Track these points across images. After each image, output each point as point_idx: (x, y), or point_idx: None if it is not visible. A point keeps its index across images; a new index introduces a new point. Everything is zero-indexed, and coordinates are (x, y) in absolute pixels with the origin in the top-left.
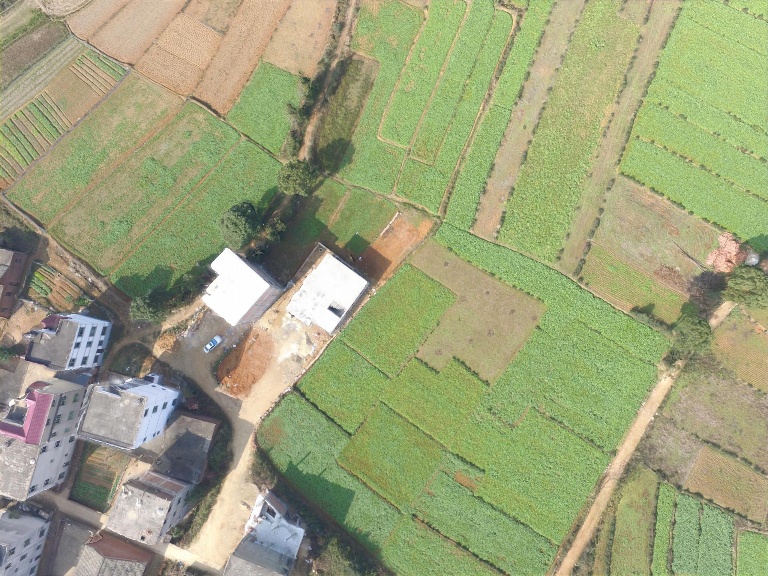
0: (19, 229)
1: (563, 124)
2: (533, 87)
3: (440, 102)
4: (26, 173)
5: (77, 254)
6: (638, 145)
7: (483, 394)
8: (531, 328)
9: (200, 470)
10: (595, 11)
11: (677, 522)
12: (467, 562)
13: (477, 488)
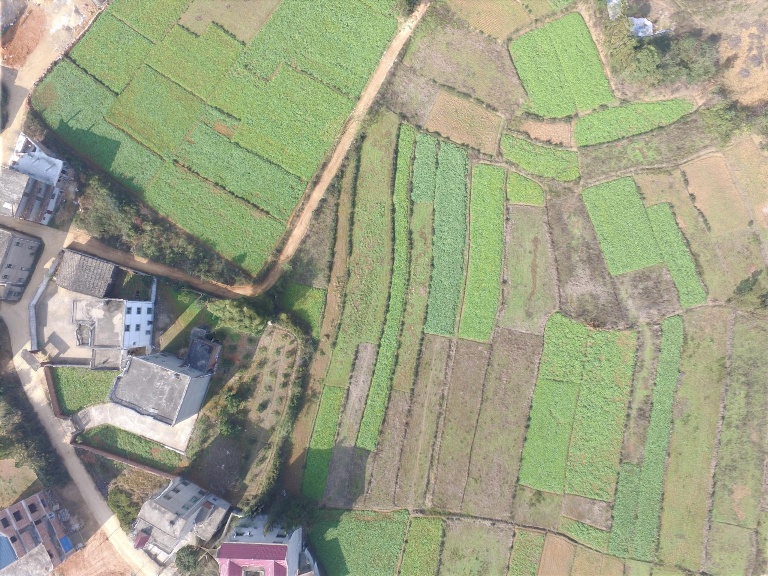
0: None
1: None
2: None
3: None
4: None
5: None
6: None
7: (239, 53)
8: None
9: None
10: None
11: (416, 158)
12: (224, 199)
13: (234, 135)
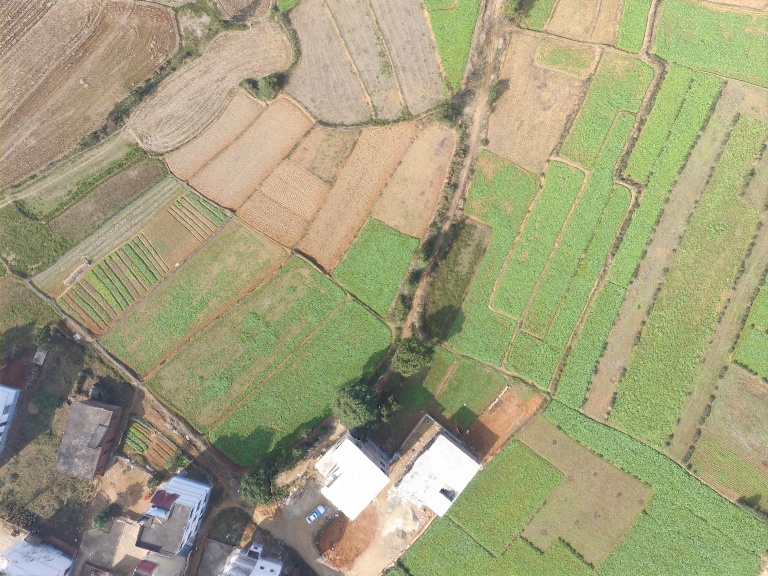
0: (113, 379)
1: (678, 307)
2: (649, 266)
3: (554, 275)
4: (121, 320)
5: (174, 410)
6: (753, 334)
7: None
8: (637, 512)
9: None
10: (716, 193)
11: None
12: None
13: None
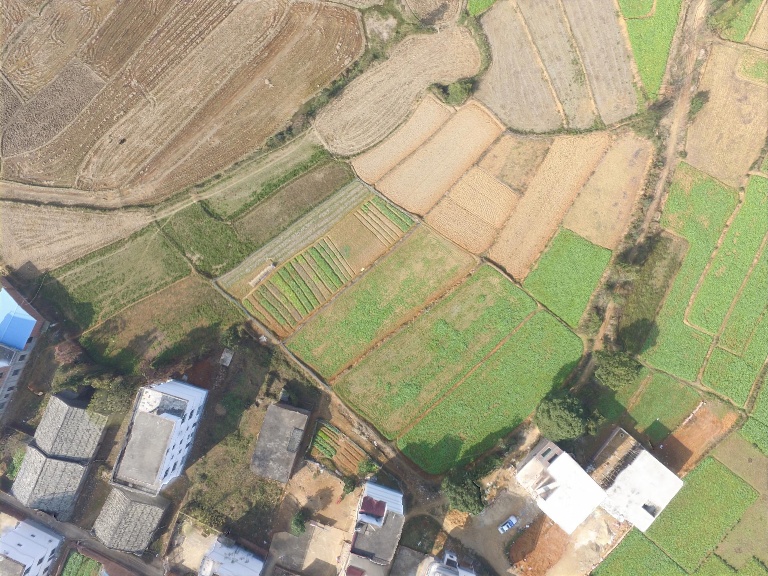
0: (300, 382)
1: None
2: None
3: (753, 291)
4: (307, 323)
5: (362, 415)
6: None
7: None
8: None
9: None
10: None
11: None
12: None
13: None
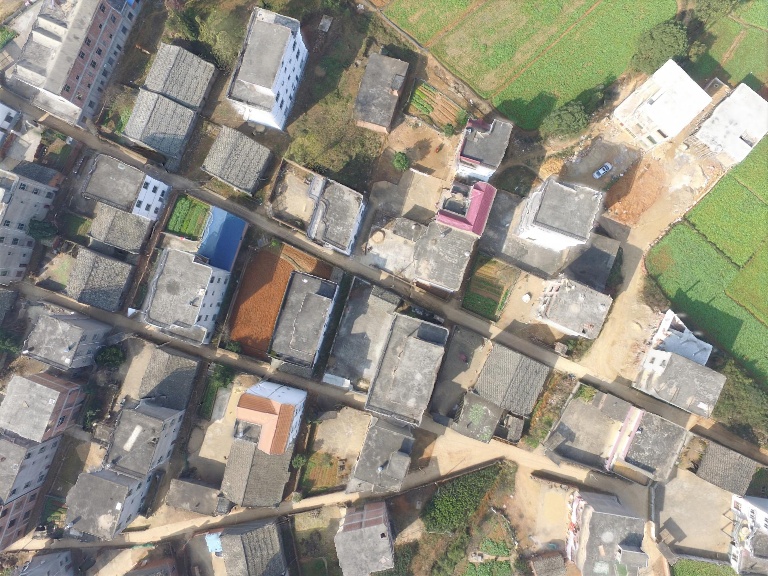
0: (397, 47)
1: None
2: None
3: None
4: None
5: (458, 75)
6: None
7: None
8: None
9: (604, 285)
10: None
11: None
12: None
13: None
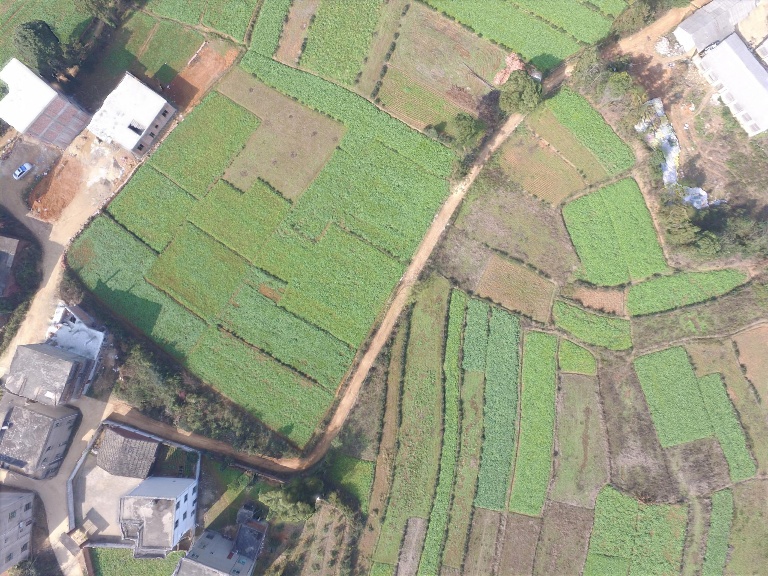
0: None
1: None
2: None
3: None
4: None
5: None
6: None
7: (286, 212)
8: (332, 149)
9: (4, 284)
10: None
11: (468, 324)
12: (270, 367)
13: (280, 299)
